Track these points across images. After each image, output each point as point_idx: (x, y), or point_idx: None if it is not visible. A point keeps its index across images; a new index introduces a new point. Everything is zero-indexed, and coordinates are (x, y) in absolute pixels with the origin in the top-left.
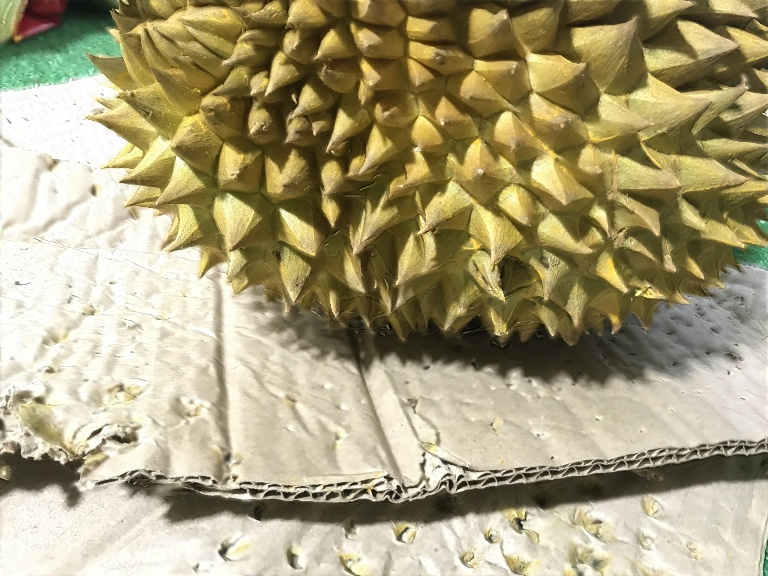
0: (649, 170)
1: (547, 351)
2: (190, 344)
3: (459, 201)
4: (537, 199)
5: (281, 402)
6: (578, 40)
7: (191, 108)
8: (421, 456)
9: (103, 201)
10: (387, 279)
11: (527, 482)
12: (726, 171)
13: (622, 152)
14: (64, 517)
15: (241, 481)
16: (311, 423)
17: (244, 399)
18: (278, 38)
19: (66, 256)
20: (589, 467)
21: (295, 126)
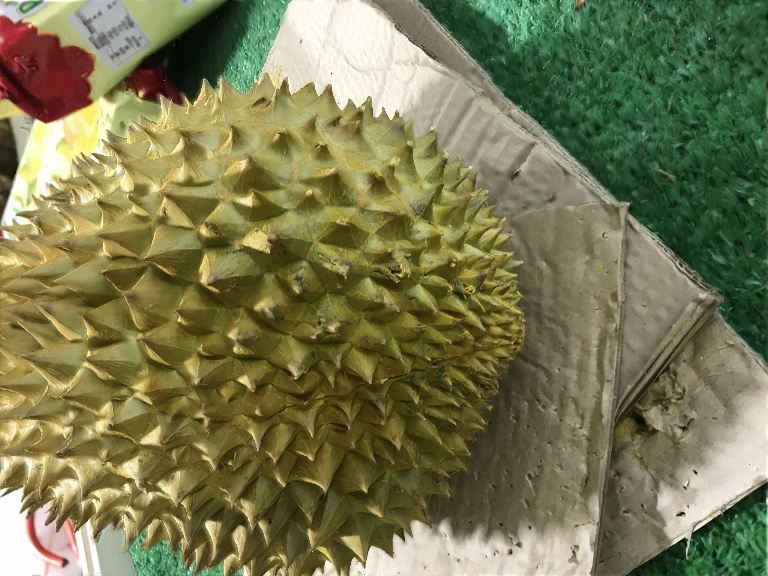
0: None
1: None
2: None
3: None
4: None
5: None
6: None
7: None
8: None
9: None
10: None
11: None
12: None
13: None
14: None
15: None
16: None
17: None
18: None
19: None
20: None
21: None
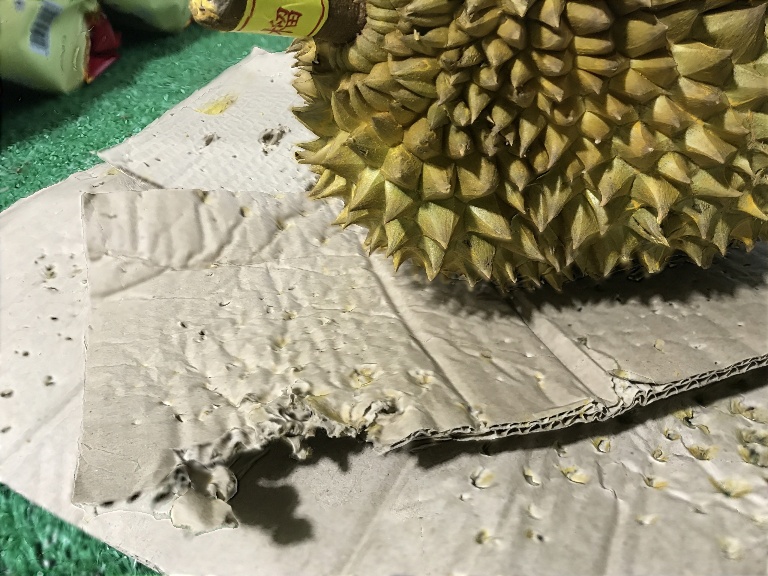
0: None
1: (678, 277)
2: (383, 328)
3: (625, 173)
4: (689, 160)
5: (481, 360)
6: (712, 27)
7: (396, 141)
8: (611, 381)
9: (253, 220)
10: (554, 245)
11: (700, 386)
12: None
13: (756, 109)
14: (344, 480)
15: (491, 425)
16: (513, 372)
17: (453, 363)
18: (473, 75)
19: (244, 274)
20: (747, 365)
21: (492, 141)
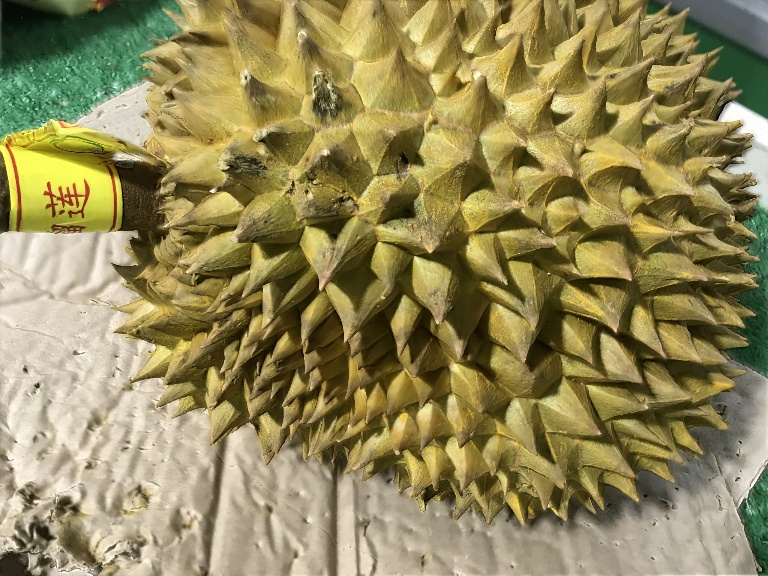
0: (545, 462)
1: None
2: (201, 436)
3: None
4: None
5: (259, 512)
6: (494, 362)
7: (186, 337)
8: None
9: None
10: None
11: None
12: (620, 461)
13: None
14: None
15: None
16: (278, 538)
17: (230, 509)
18: (245, 328)
19: (116, 320)
20: None
21: None
